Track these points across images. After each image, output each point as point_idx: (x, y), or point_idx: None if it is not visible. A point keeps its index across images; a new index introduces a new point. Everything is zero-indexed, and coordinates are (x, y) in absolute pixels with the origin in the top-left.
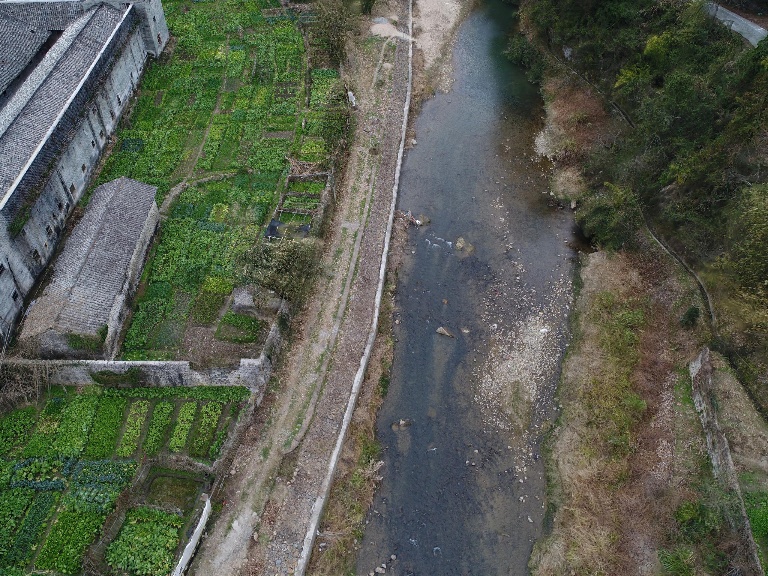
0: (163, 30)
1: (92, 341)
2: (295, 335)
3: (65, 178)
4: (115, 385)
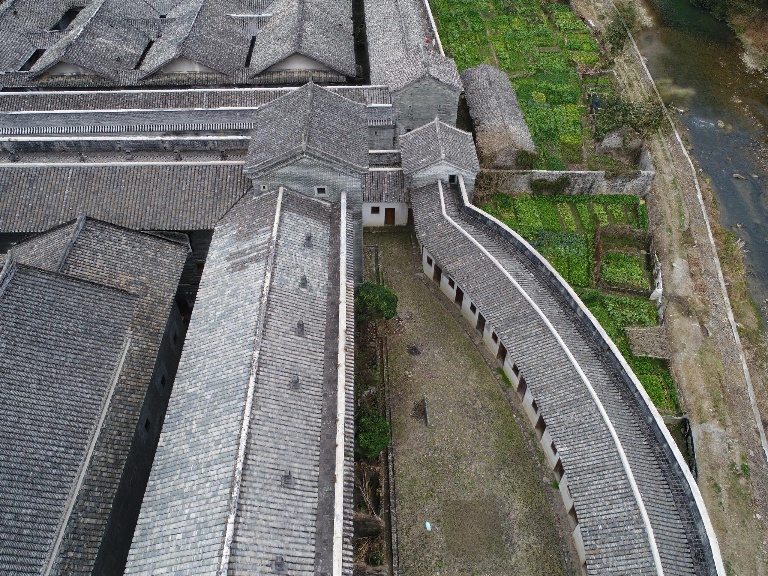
0: None
1: (535, 157)
2: None
3: None
4: (541, 193)
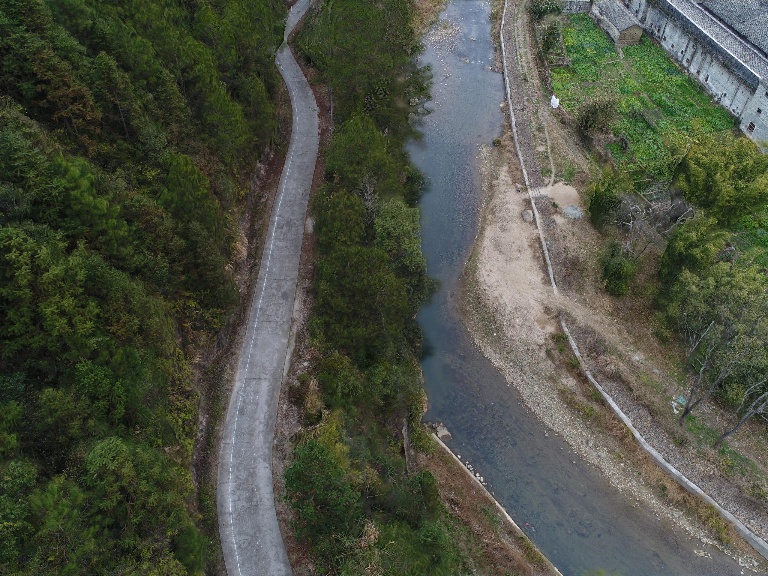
0: (762, 137)
1: None
2: None
3: None
4: None
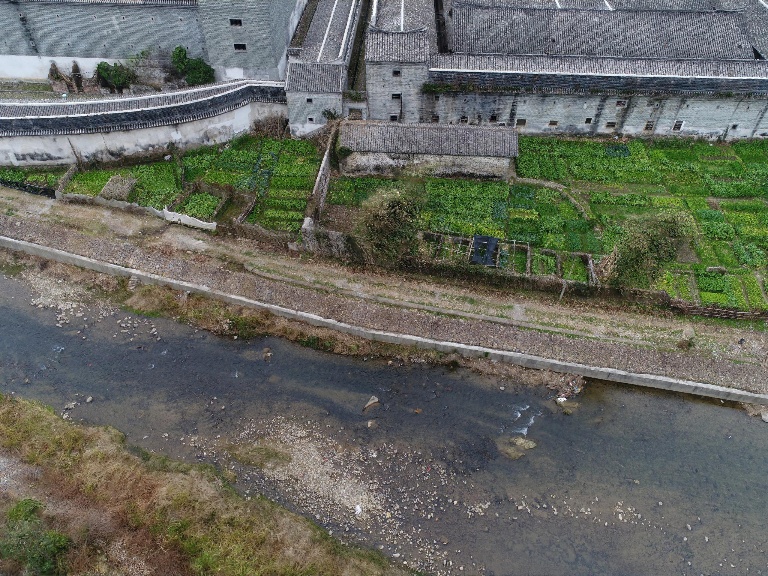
0: None
1: (336, 147)
2: (358, 268)
3: (520, 110)
4: None
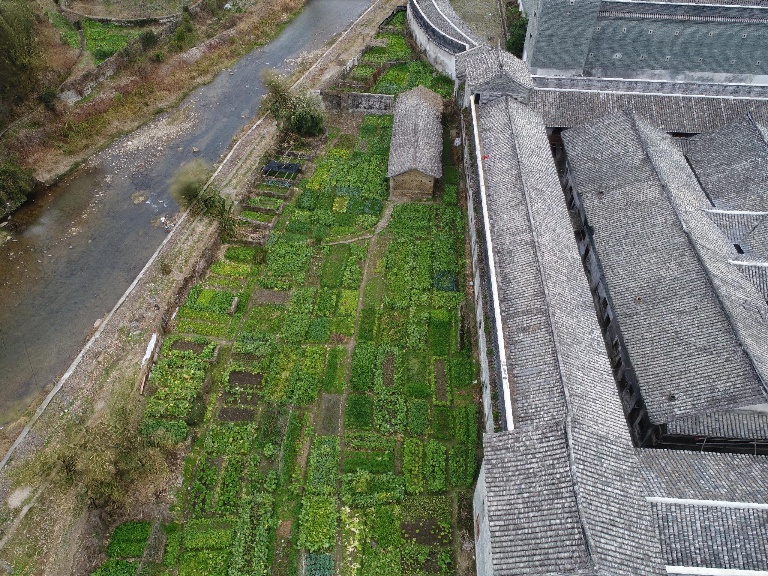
0: None
1: None
2: None
3: None
4: None
